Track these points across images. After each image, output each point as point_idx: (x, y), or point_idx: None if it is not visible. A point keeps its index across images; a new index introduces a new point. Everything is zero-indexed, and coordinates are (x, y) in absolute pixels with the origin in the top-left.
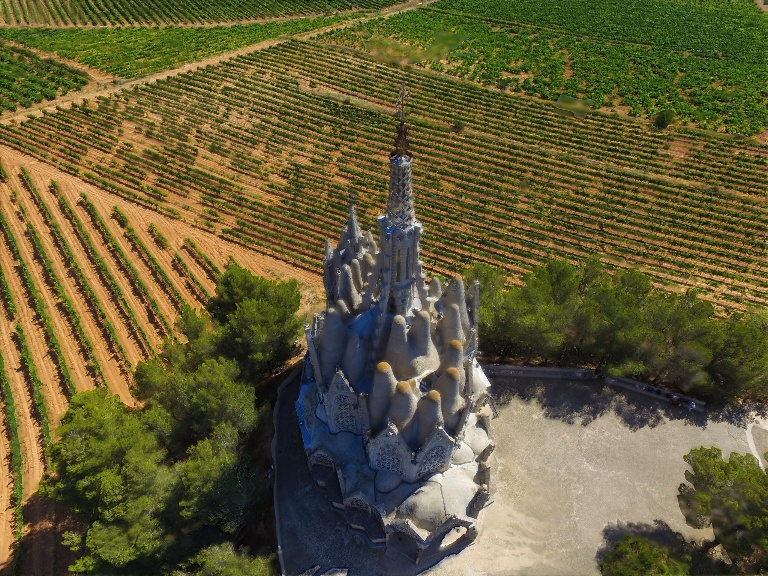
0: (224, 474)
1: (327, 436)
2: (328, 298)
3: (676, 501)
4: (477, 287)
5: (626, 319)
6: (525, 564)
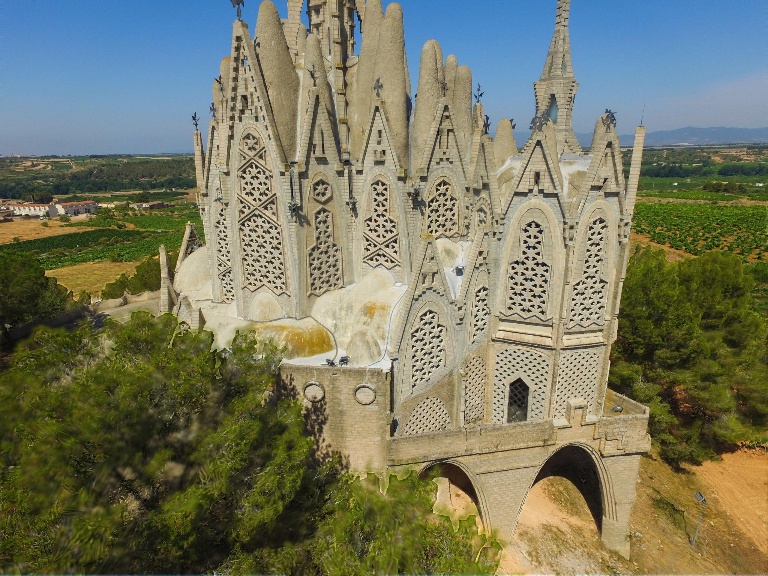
0: None
1: None
2: None
3: None
4: (236, 33)
5: None
6: None
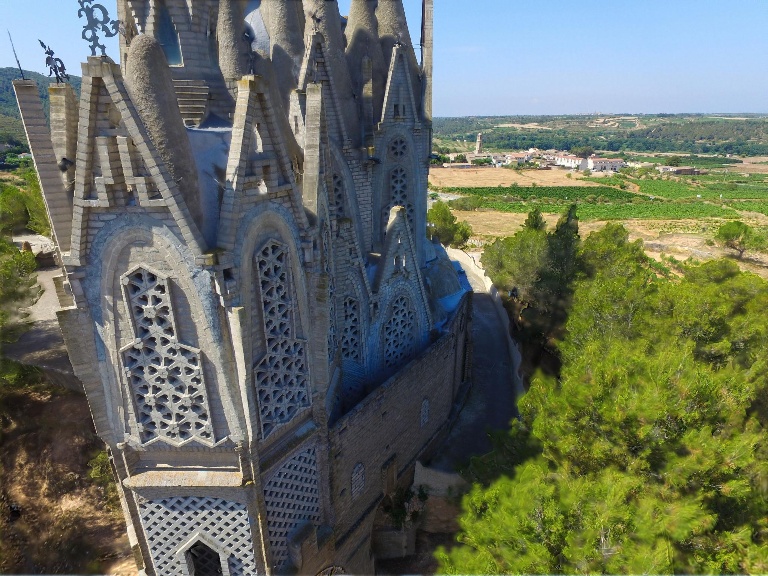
0: None
1: None
2: None
3: None
4: None
5: None
6: None
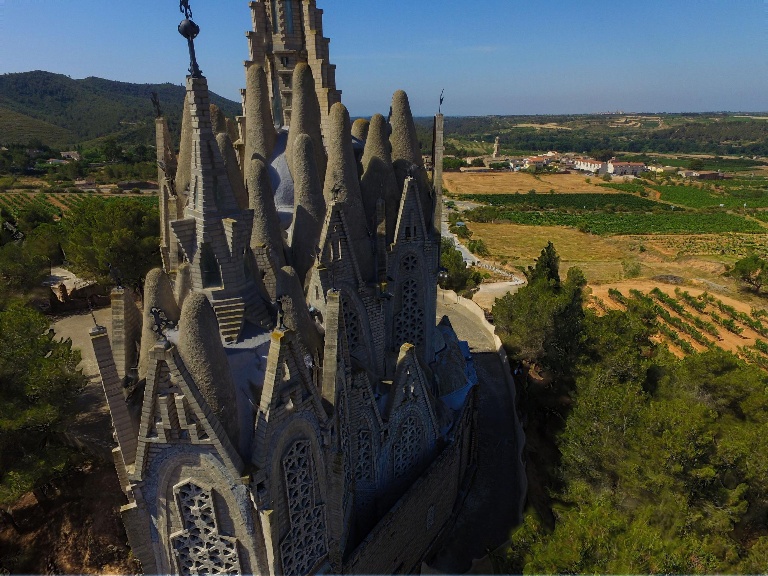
0: None
1: None
2: None
3: None
4: None
5: None
6: None
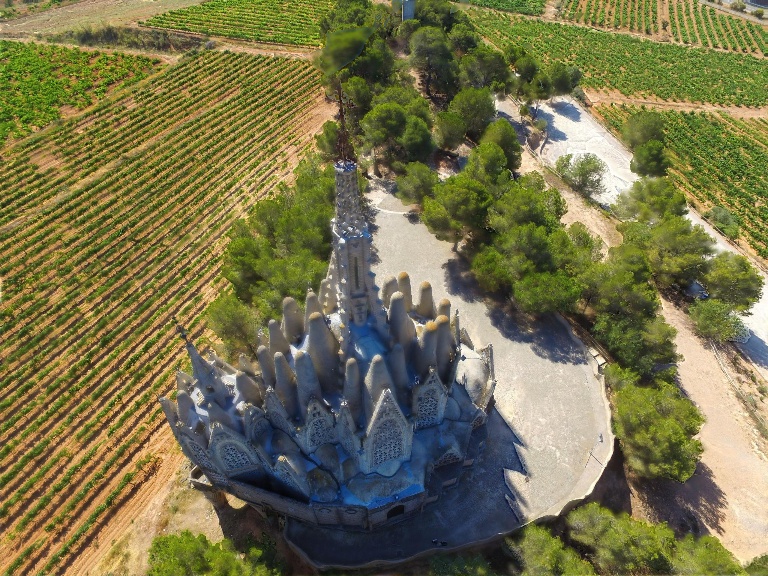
0: (472, 570)
1: (414, 463)
2: (256, 445)
3: (429, 255)
4: None
5: (322, 214)
6: (479, 342)
